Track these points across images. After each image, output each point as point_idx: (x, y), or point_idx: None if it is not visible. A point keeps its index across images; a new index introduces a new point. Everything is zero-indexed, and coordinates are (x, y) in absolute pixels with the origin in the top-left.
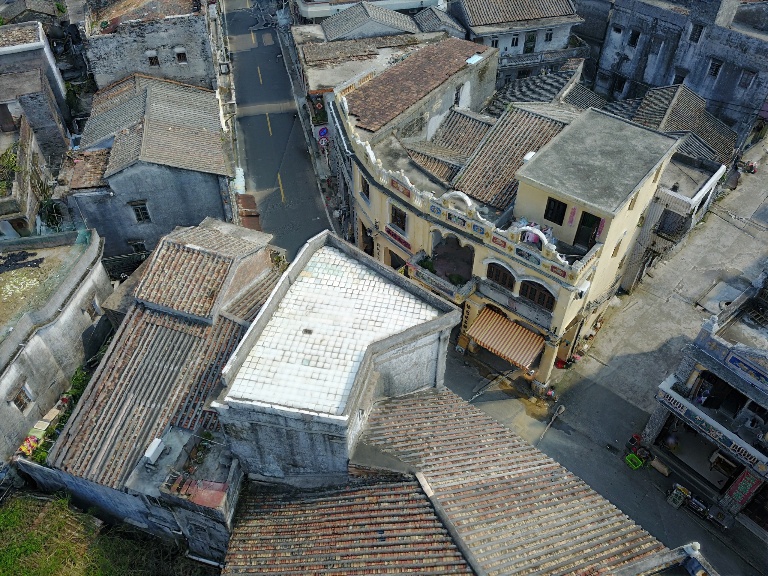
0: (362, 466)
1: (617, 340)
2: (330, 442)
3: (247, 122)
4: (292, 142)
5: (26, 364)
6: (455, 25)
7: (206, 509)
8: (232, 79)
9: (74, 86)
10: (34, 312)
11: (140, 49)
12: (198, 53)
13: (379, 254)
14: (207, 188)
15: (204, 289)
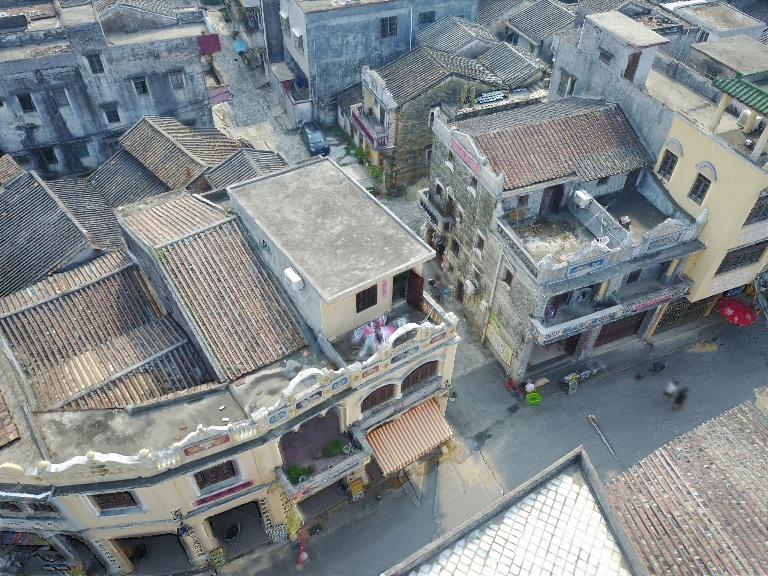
0: None
1: None
2: None
3: None
4: None
5: None
6: None
7: None
8: None
9: None
10: None
11: None
12: None
13: (194, 536)
14: None
15: None
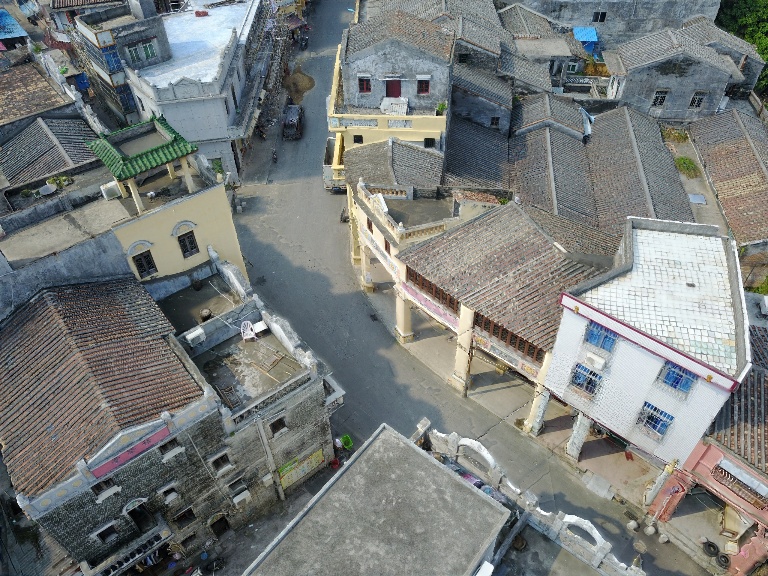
0: None
1: None
2: None
3: None
4: None
5: None
6: None
7: None
8: None
9: None
10: None
11: None
12: None
13: None
14: None
15: None
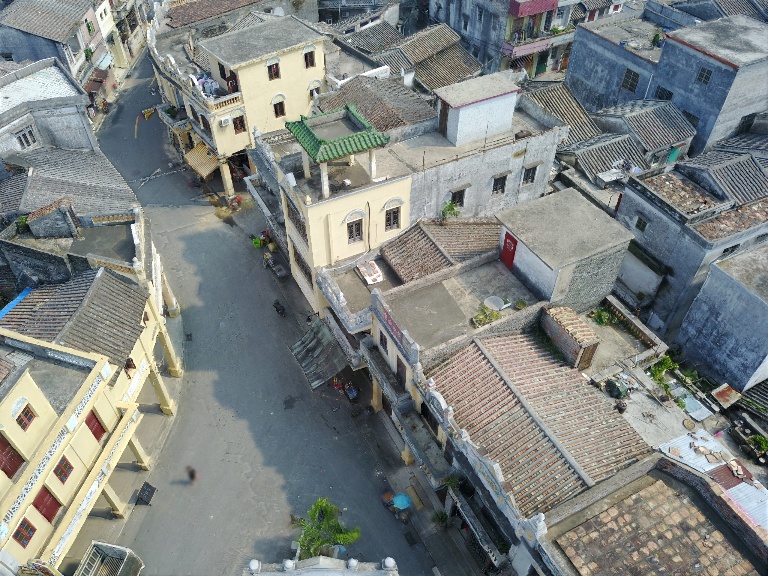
0: (7, 162)
1: None
2: None
3: None
4: None
5: None
6: None
7: None
8: None
9: None
10: None
11: None
12: None
13: None
14: (50, 50)
15: None
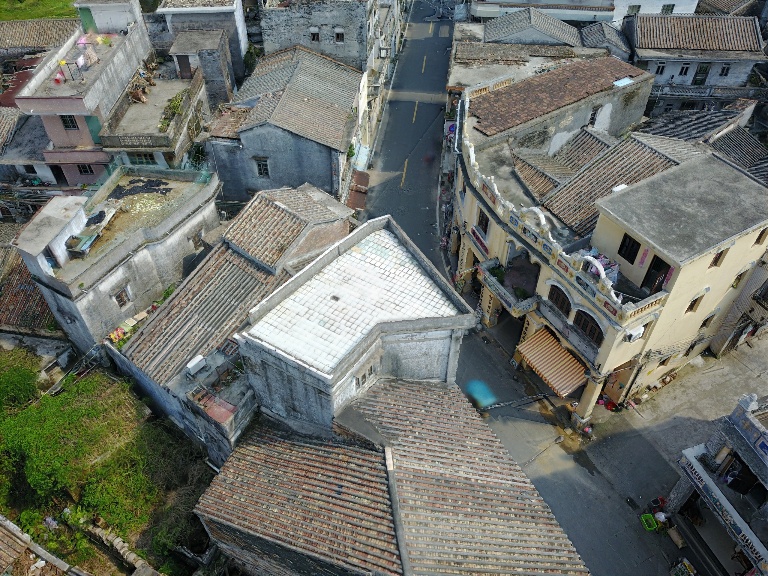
0: (343, 426)
1: (683, 400)
2: (319, 396)
3: (396, 106)
4: (430, 132)
5: (132, 270)
6: (620, 44)
7: (215, 422)
8: (385, 64)
9: (256, 49)
10: (147, 229)
11: (305, 25)
12: (355, 35)
13: (463, 253)
14: (321, 158)
15: (277, 243)
